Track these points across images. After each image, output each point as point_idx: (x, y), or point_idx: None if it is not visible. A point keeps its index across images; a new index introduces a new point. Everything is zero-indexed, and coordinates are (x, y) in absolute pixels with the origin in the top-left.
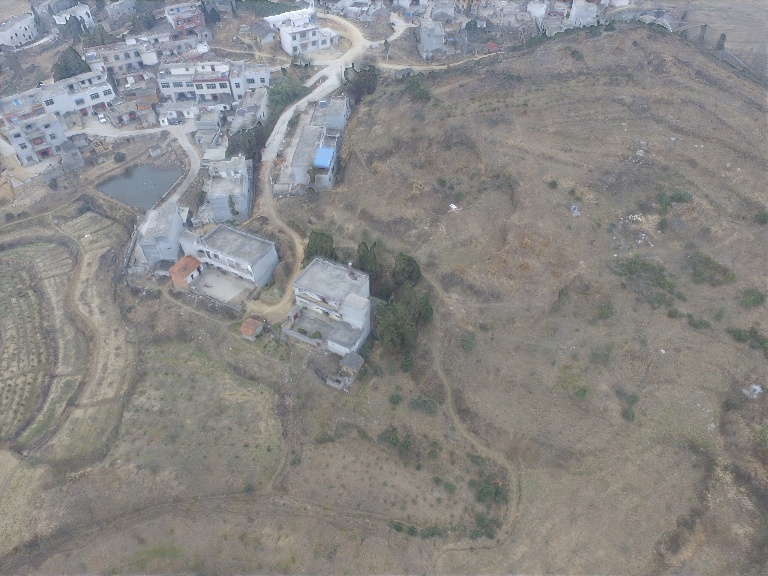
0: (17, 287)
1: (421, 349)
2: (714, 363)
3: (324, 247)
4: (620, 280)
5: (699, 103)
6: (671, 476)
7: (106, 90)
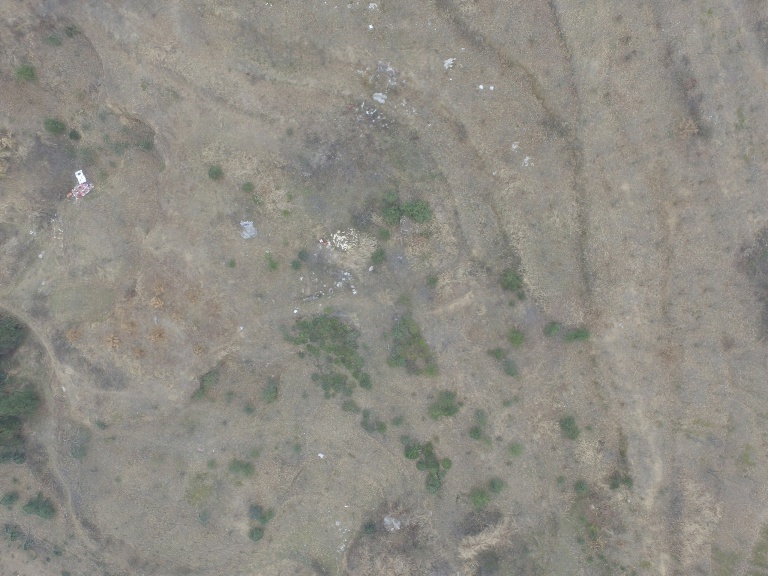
0: None
1: (31, 443)
2: (372, 477)
3: None
4: (295, 350)
5: None
6: None
7: None
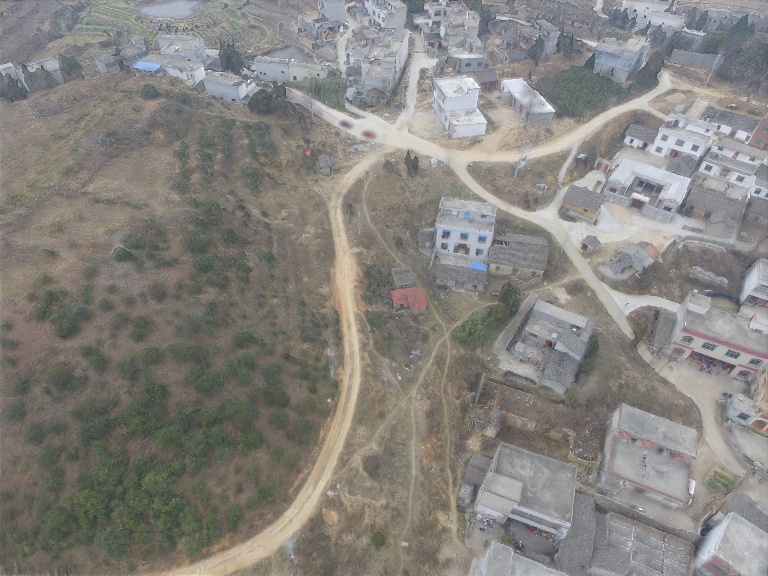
0: (226, 41)
1: None
2: None
3: None
4: None
5: None
6: None
7: (384, 18)
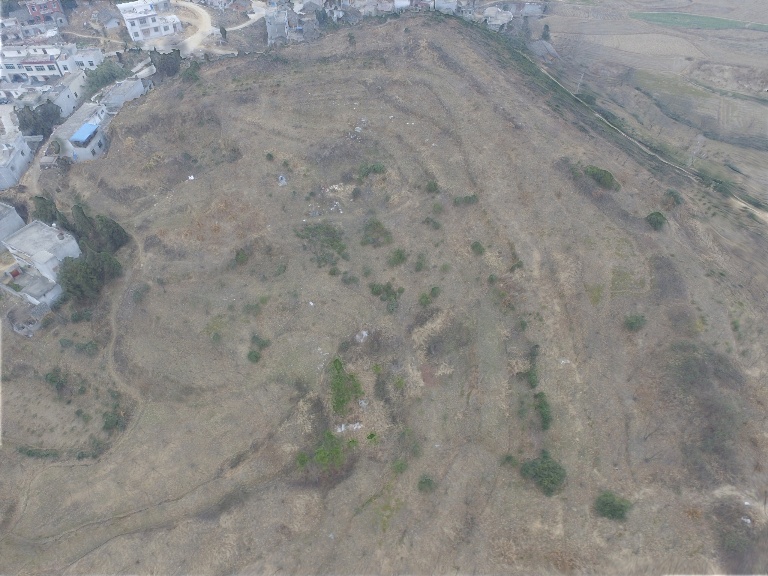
0: None
1: (103, 300)
2: (348, 313)
3: (43, 210)
4: (301, 242)
5: (428, 85)
6: (268, 407)
7: None
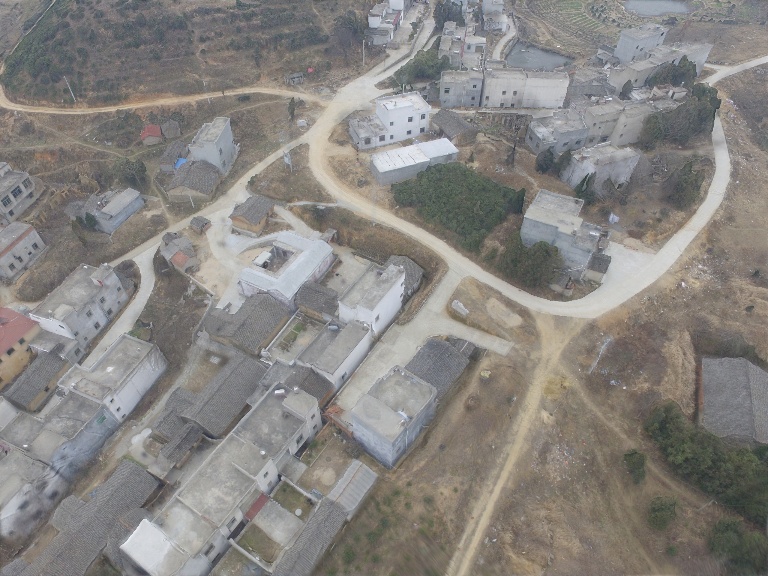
0: None
1: None
2: None
3: None
4: None
5: None
6: None
7: None
